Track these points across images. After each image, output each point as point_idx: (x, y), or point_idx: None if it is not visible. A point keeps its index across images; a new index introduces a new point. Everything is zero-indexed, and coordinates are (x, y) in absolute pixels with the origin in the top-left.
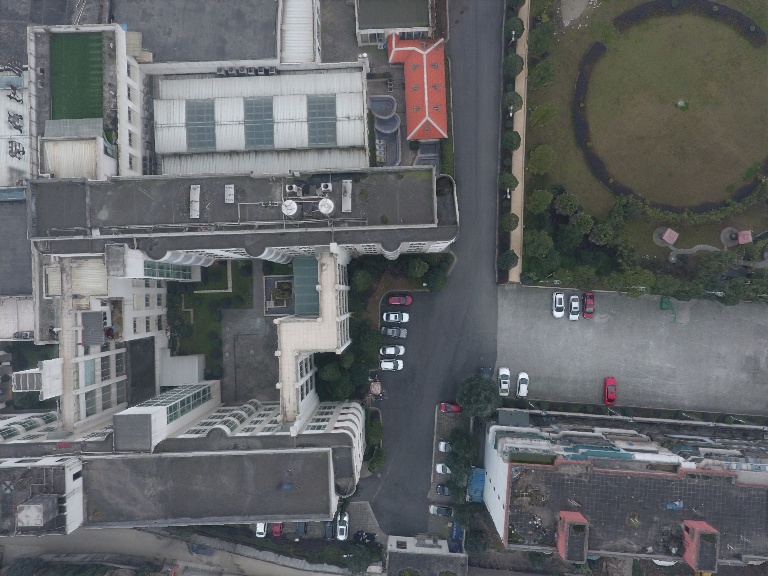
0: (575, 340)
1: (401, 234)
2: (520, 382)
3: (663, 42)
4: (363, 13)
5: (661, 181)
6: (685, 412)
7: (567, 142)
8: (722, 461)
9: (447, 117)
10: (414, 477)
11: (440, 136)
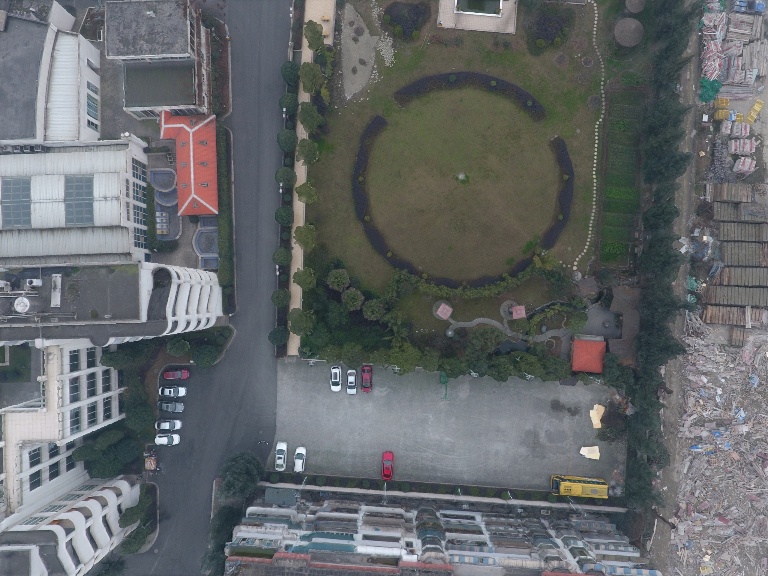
0: (354, 414)
1: (111, 329)
2: (296, 457)
3: (444, 116)
4: (130, 91)
5: (441, 254)
6: (462, 487)
7: (348, 215)
8: (456, 550)
9: (222, 192)
10: (191, 553)
11: (210, 212)
